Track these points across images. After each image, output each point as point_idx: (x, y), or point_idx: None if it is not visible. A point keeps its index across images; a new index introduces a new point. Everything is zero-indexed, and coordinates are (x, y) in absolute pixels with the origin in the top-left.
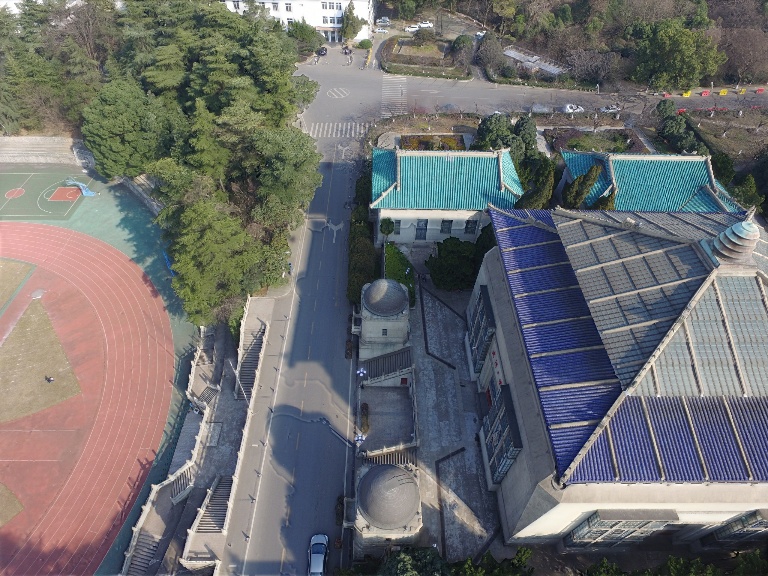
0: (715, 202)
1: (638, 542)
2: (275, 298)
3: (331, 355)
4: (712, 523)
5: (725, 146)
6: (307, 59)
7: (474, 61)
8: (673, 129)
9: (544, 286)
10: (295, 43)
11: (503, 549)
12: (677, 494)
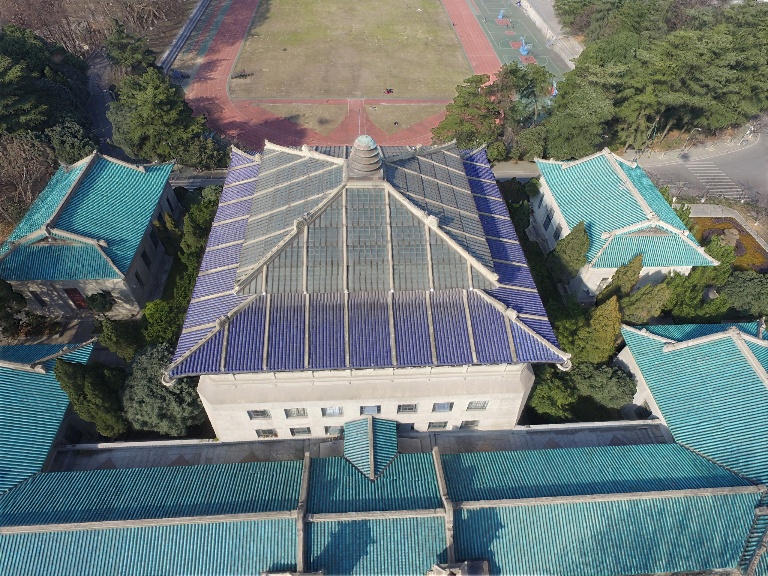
0: None
1: None
2: None
3: None
4: None
5: None
6: None
7: None
8: None
9: None
10: None
11: None
12: None
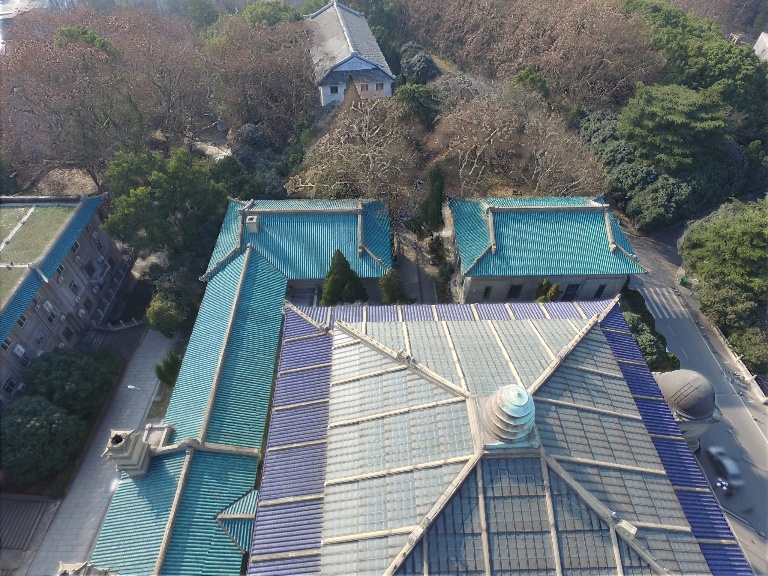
0: None
1: None
2: None
3: None
4: None
5: None
6: None
7: None
8: None
9: (680, 499)
10: None
11: None
12: None
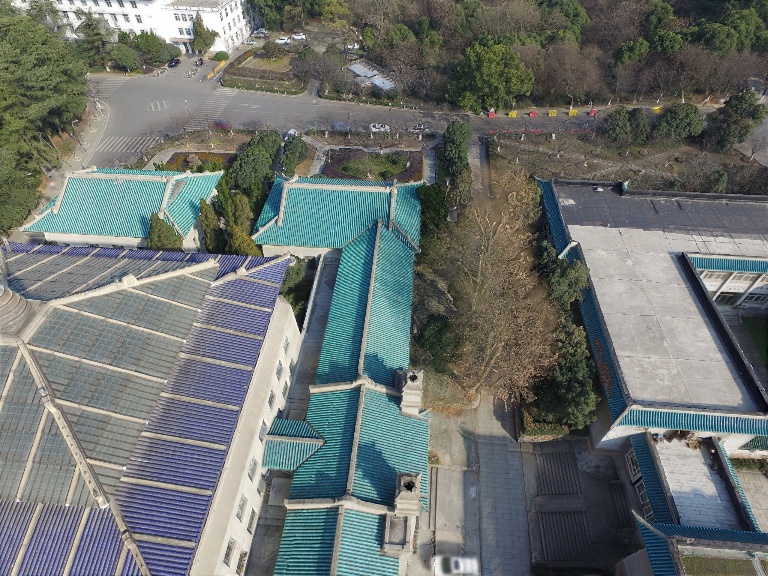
0: None
1: None
2: None
3: None
4: None
5: None
6: (154, 71)
7: (316, 75)
8: (453, 153)
9: None
10: (135, 55)
11: None
12: None
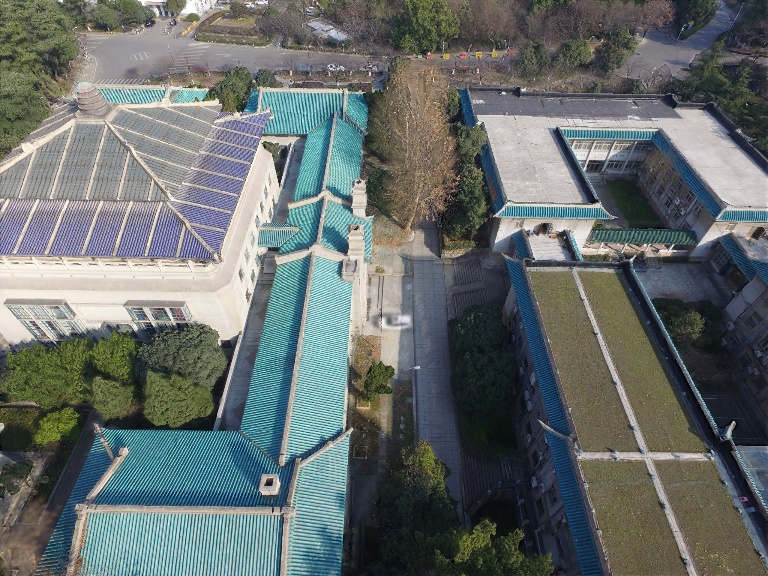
0: None
1: None
2: None
3: None
4: (127, 322)
5: None
6: (132, 30)
7: (279, 31)
8: (395, 81)
9: None
10: (115, 14)
11: None
12: (51, 283)
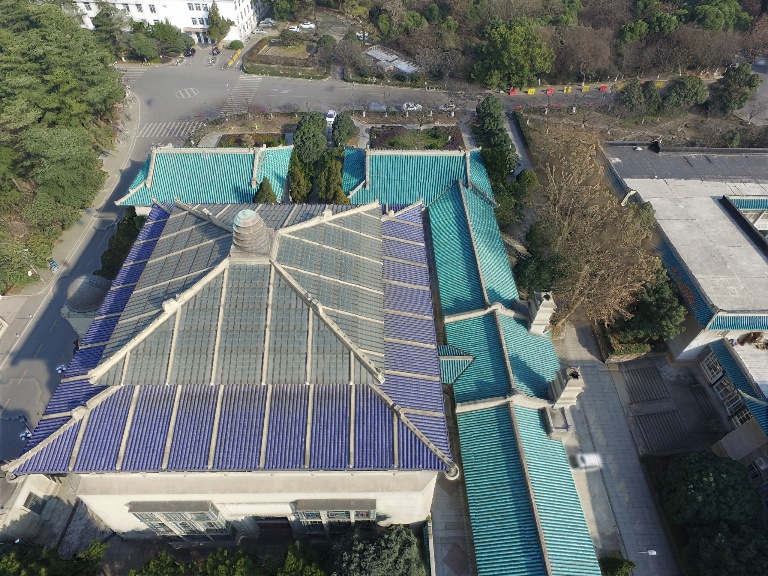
0: (460, 196)
1: (256, 536)
2: (28, 296)
3: (60, 353)
4: (284, 515)
5: (545, 142)
6: (172, 60)
7: (336, 61)
8: (491, 126)
9: None
10: (154, 44)
11: (119, 545)
12: (197, 485)
